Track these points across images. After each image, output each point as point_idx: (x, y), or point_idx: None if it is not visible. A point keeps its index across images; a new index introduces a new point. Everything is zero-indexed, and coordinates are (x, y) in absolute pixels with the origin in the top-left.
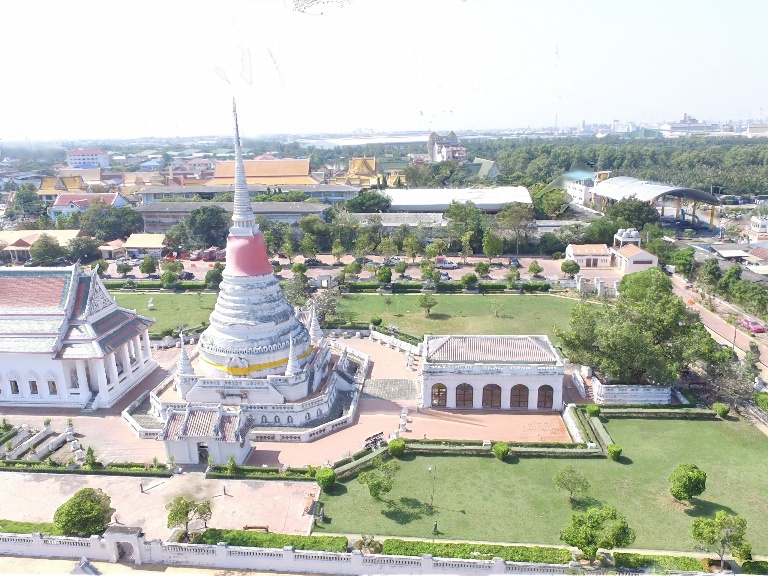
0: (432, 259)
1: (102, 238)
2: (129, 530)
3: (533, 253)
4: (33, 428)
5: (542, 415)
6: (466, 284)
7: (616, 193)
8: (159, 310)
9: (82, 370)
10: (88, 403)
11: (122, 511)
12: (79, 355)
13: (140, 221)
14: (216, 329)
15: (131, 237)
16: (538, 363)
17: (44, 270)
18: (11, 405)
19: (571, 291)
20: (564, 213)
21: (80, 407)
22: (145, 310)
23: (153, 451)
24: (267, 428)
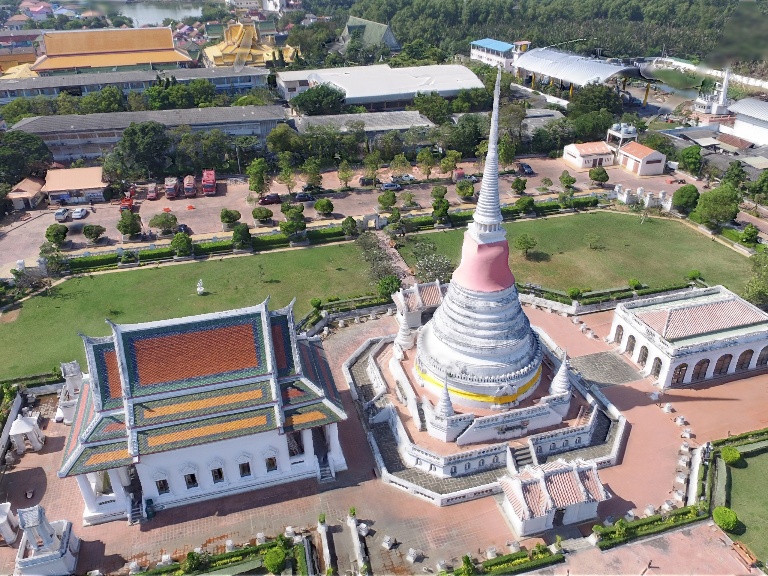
0: (447, 173)
1: (1, 180)
2: None
3: (527, 152)
4: (299, 529)
5: (766, 374)
6: None
7: (553, 70)
8: (214, 294)
9: (311, 436)
10: (320, 470)
11: None
12: (315, 422)
13: (46, 149)
14: (462, 353)
15: (50, 176)
16: (753, 324)
17: (219, 317)
18: (215, 497)
19: (617, 204)
20: (508, 95)
21: (310, 477)
22: (195, 296)
23: (480, 522)
24: (561, 456)
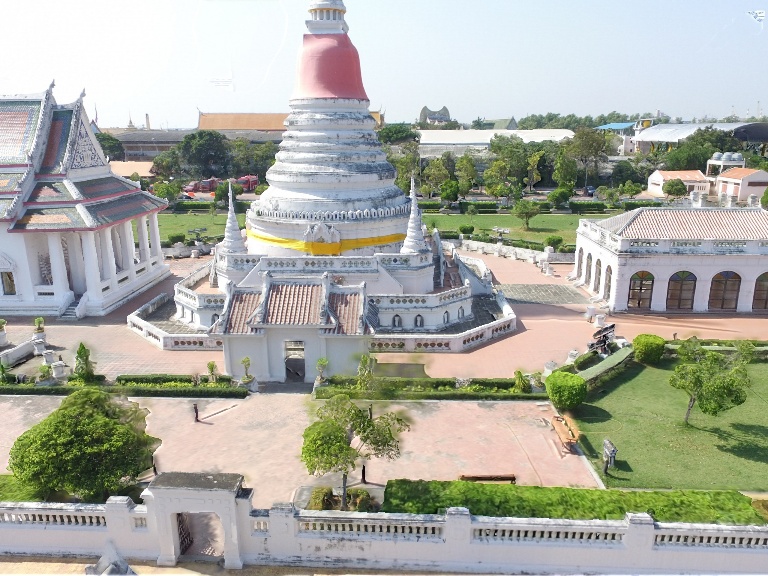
0: None
1: None
2: (211, 480)
3: None
4: None
5: None
6: (556, 202)
7: (671, 136)
8: None
9: (58, 253)
10: (68, 308)
11: (162, 454)
12: (54, 224)
13: (120, 149)
14: (280, 188)
15: None
16: None
17: None
18: None
19: None
20: None
21: (54, 314)
22: None
23: (193, 366)
24: (382, 334)
